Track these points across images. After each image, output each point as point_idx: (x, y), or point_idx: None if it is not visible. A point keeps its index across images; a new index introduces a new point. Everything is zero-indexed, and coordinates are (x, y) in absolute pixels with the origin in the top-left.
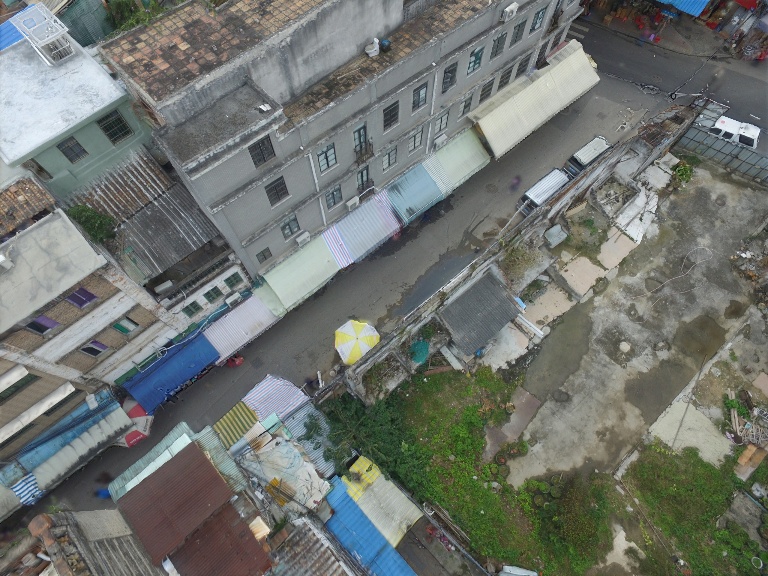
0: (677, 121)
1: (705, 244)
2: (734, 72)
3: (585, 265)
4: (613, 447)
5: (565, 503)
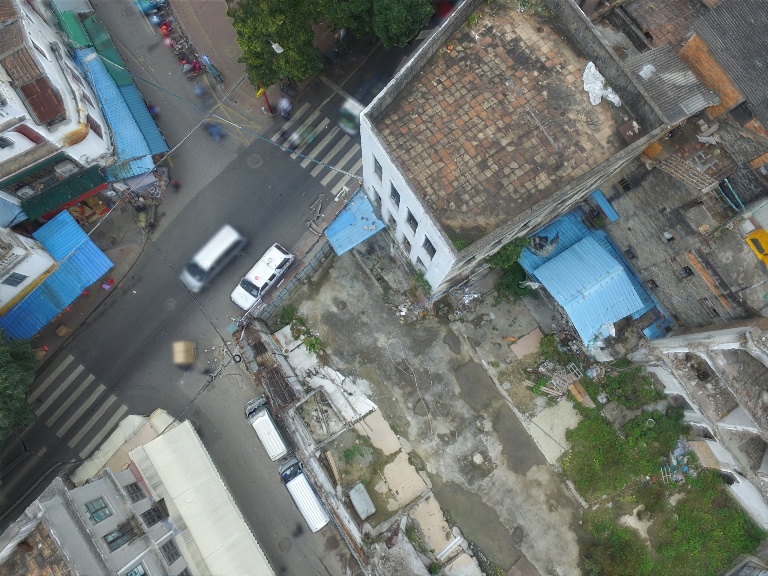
0: (262, 352)
1: (385, 341)
2: (179, 216)
3: (393, 470)
4: (562, 500)
5: (613, 575)
